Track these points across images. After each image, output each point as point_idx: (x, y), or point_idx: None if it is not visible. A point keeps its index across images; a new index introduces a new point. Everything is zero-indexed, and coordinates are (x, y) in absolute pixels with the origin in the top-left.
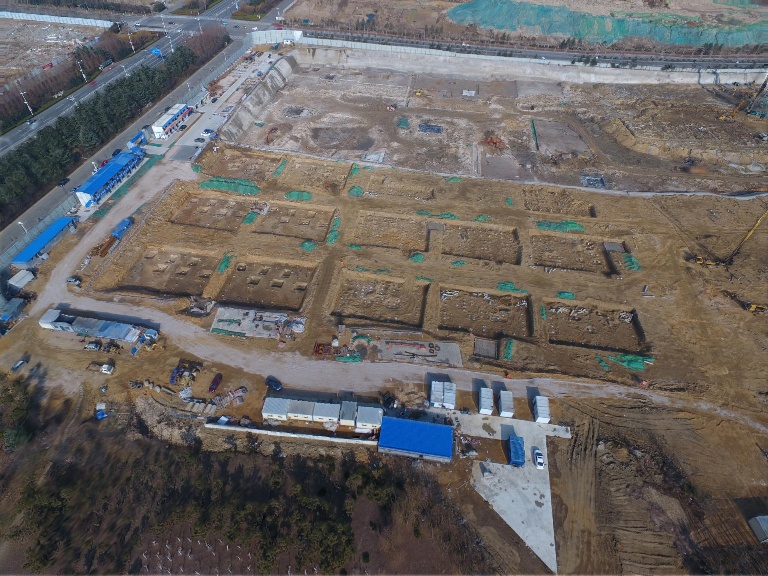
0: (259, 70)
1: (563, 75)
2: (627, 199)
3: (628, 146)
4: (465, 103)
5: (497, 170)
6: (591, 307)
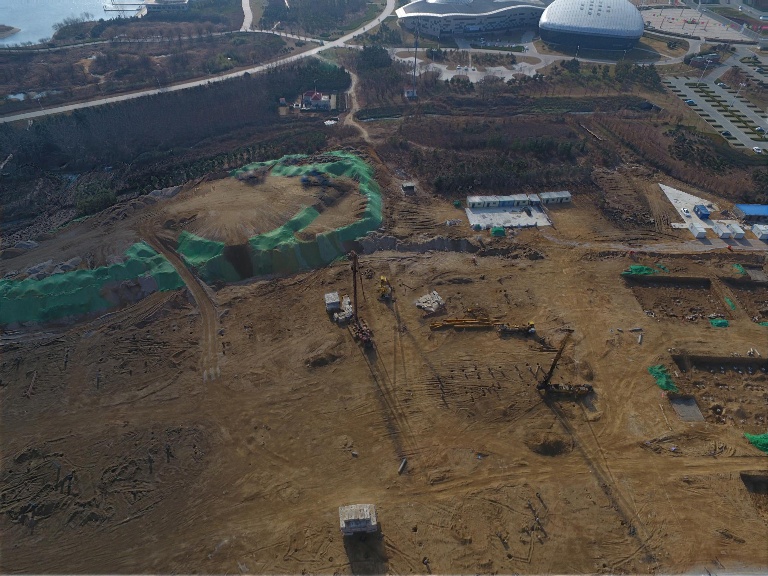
0: None
1: None
2: (705, 550)
3: None
4: None
5: None
6: None
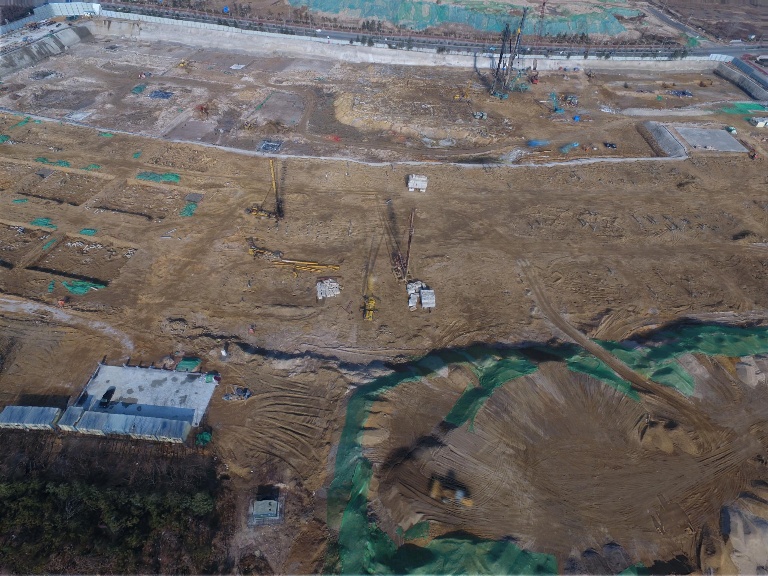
0: (33, 37)
1: (341, 54)
2: (257, 159)
3: (338, 118)
4: (221, 75)
5: (185, 132)
6: (108, 244)
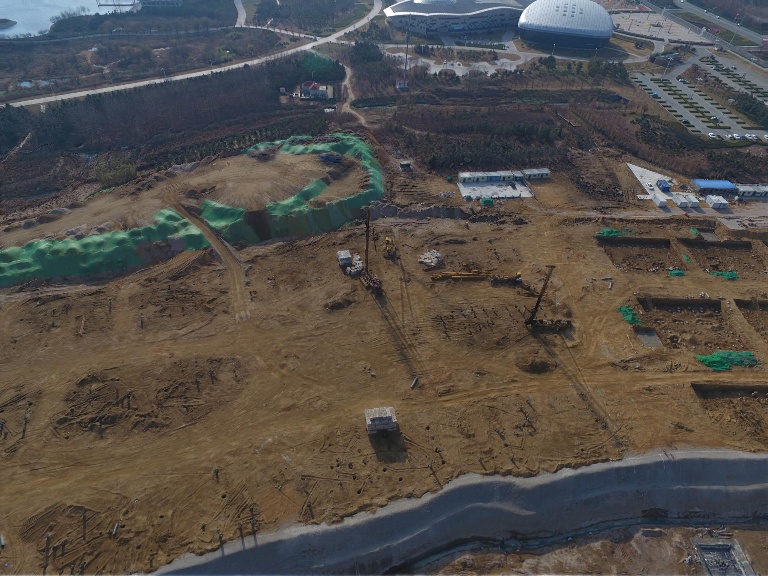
0: None
1: None
2: (662, 437)
3: None
4: None
5: None
6: None
